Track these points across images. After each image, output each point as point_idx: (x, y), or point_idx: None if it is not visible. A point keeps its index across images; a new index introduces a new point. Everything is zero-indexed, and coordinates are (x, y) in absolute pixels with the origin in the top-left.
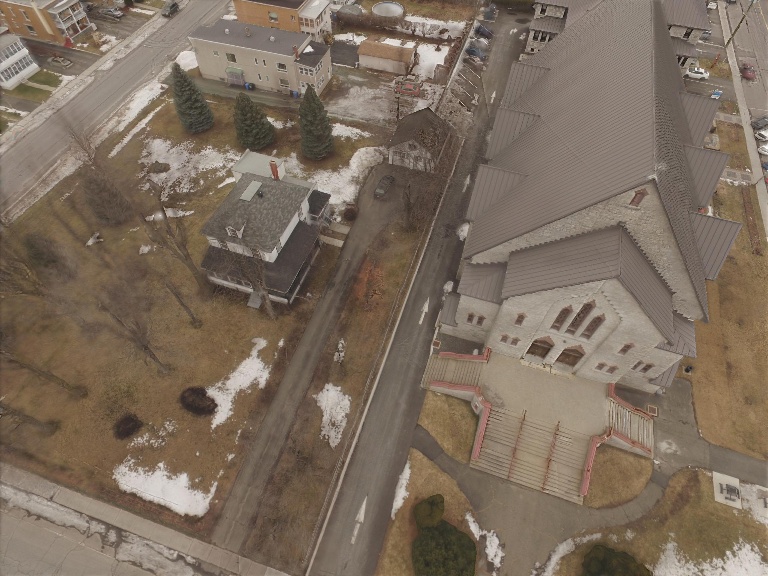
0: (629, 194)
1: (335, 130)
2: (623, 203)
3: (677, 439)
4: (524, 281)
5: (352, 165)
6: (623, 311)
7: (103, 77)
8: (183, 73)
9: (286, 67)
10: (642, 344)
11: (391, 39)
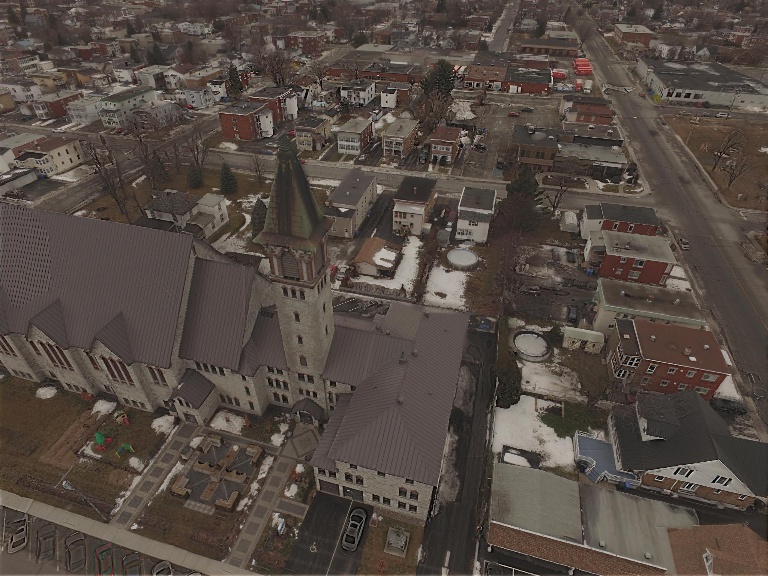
0: None
1: None
2: None
3: None
4: None
5: None
6: None
7: None
8: None
9: None
10: None
11: (394, 254)
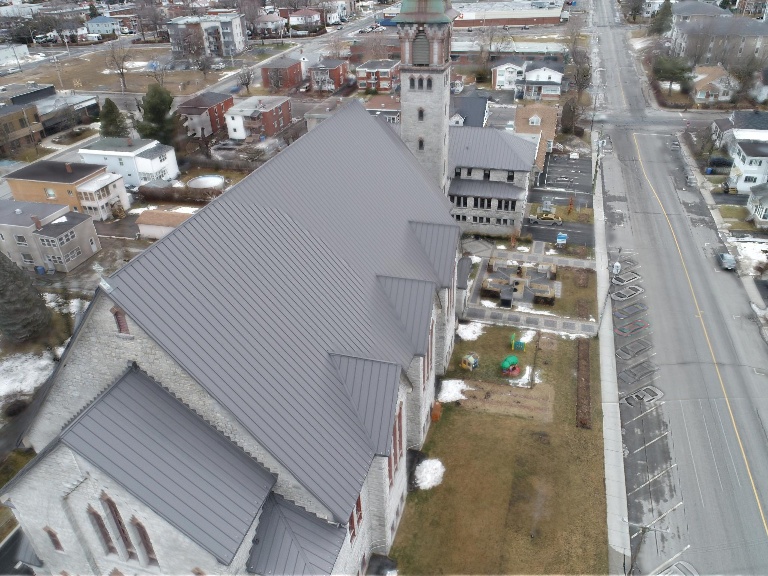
0: (107, 316)
1: (69, 306)
2: (111, 331)
3: None
4: (23, 468)
5: (64, 345)
6: (137, 505)
7: None
8: None
9: (25, 239)
10: (209, 568)
11: (186, 207)
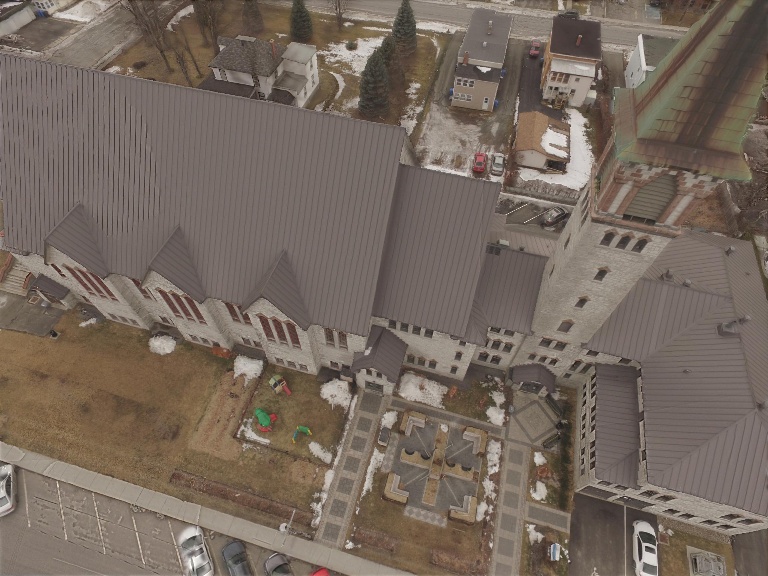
0: None
1: (407, 121)
2: None
3: (3, 310)
4: None
5: None
6: None
7: (457, 8)
8: (405, 7)
9: None
10: None
11: (564, 138)
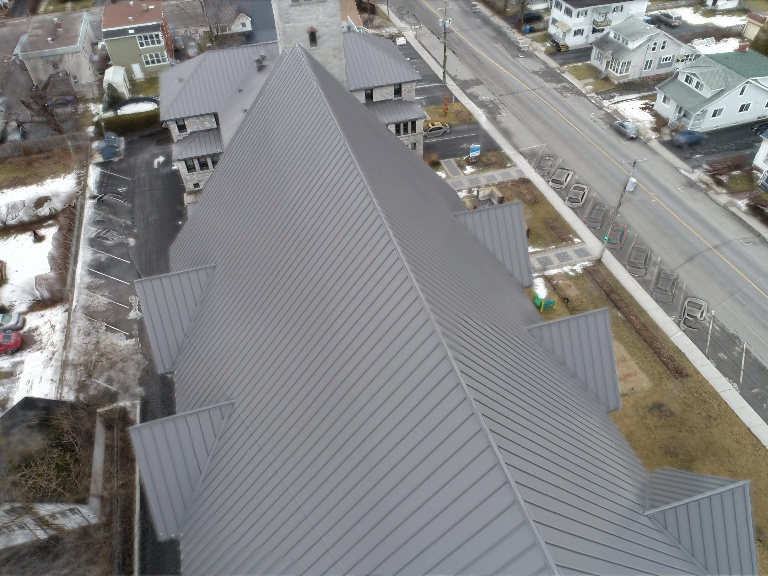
0: None
1: None
2: None
3: None
4: None
5: None
6: None
7: None
8: None
9: None
10: None
11: None
